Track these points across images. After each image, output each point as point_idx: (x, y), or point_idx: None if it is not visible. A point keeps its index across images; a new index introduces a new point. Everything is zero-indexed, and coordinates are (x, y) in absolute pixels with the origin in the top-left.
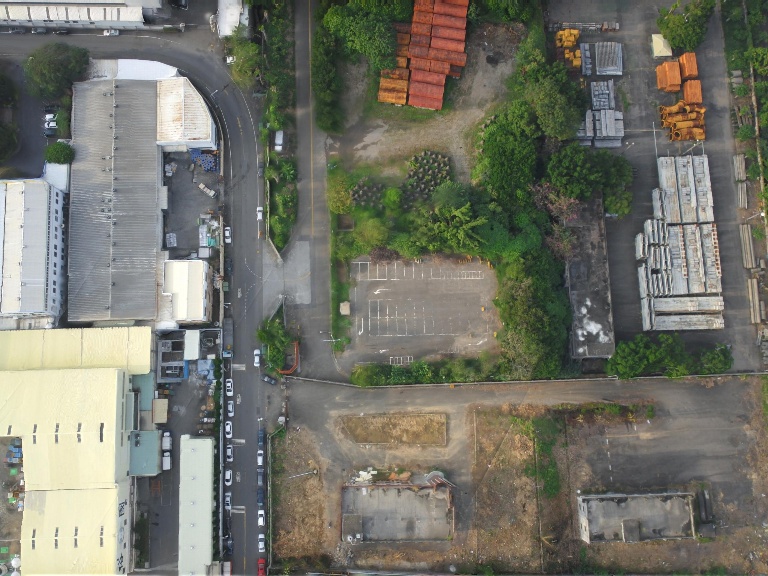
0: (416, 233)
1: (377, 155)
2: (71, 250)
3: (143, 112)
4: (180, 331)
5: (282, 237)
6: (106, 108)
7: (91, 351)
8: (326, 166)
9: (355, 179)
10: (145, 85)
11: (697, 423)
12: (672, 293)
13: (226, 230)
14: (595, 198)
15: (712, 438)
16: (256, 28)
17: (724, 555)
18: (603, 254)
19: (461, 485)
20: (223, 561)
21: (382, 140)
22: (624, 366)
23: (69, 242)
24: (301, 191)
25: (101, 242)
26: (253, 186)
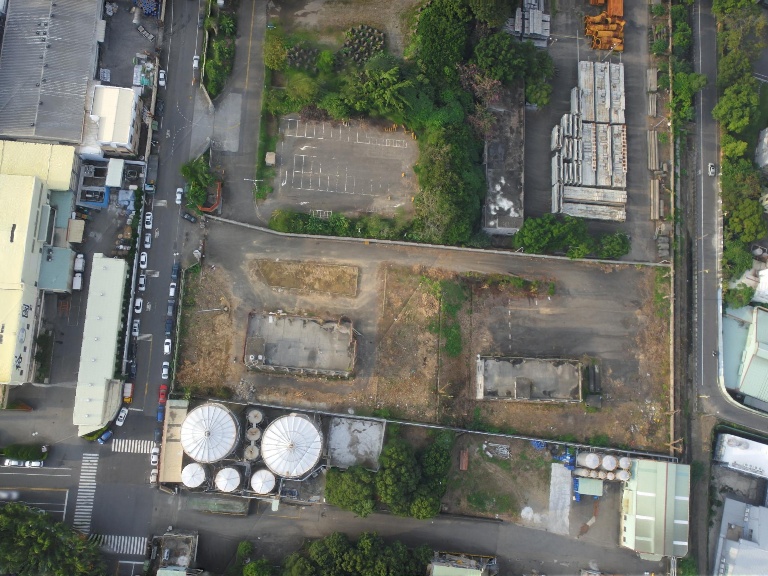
0: (345, 91)
1: (316, 23)
2: (1, 67)
3: None
4: (105, 162)
5: (215, 84)
6: None
7: (11, 163)
8: (266, 27)
9: (293, 42)
10: None
11: (594, 304)
12: (581, 182)
13: (161, 72)
14: (517, 87)
15: (606, 319)
16: None
17: (608, 425)
18: (520, 138)
19: (367, 334)
20: (124, 382)
21: (322, 10)
22: (530, 238)
23: (0, 60)
24: (239, 47)
25: (33, 63)
26: (192, 36)
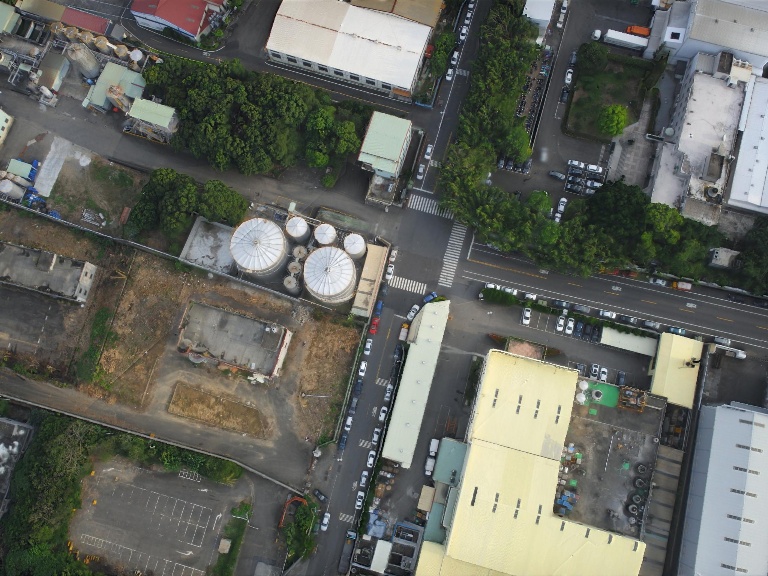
0: None
1: None
2: None
3: None
4: (393, 574)
5: None
6: None
7: None
8: None
9: None
10: None
11: None
12: None
13: None
14: None
15: None
16: None
17: None
18: None
19: None
20: None
21: None
22: None
23: None
24: None
25: None
26: None
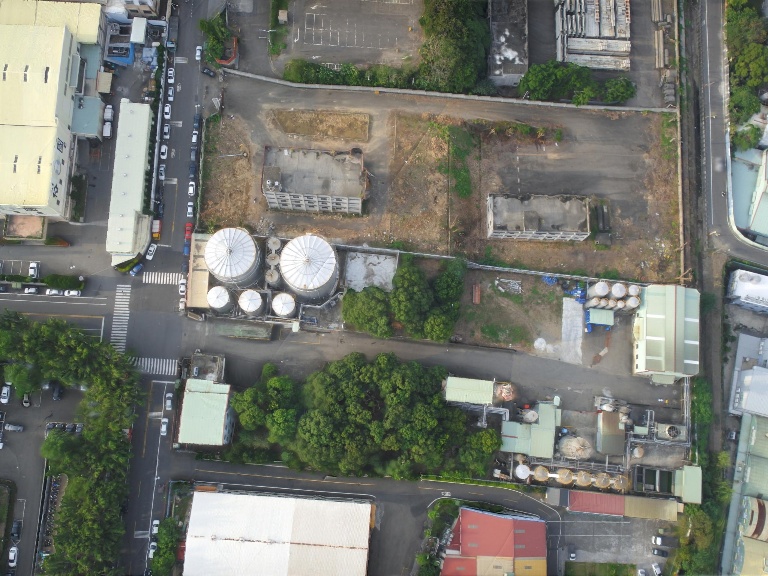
0: None
1: None
2: None
3: None
4: (129, 24)
5: None
6: None
7: (44, 20)
8: None
9: None
10: None
11: (601, 149)
12: (584, 32)
13: None
14: None
15: (614, 162)
16: None
17: (618, 262)
18: None
19: (379, 176)
20: (153, 219)
21: None
22: (534, 81)
23: None
24: None
25: None
26: None
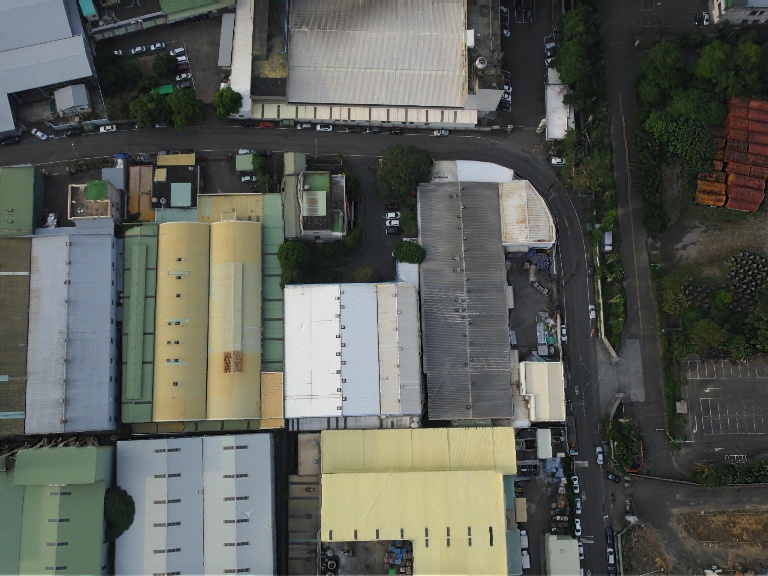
0: (756, 336)
1: (697, 255)
2: (427, 349)
3: (490, 214)
4: (525, 428)
5: (619, 336)
6: (453, 209)
7: (459, 451)
8: (649, 265)
9: (678, 279)
10: (488, 187)
11: None
12: None
13: (563, 328)
14: None
15: None
16: (581, 131)
17: None
18: None
19: None
20: None
21: (700, 240)
22: None
23: (424, 341)
24: (627, 290)
25: (457, 342)
26: (583, 284)
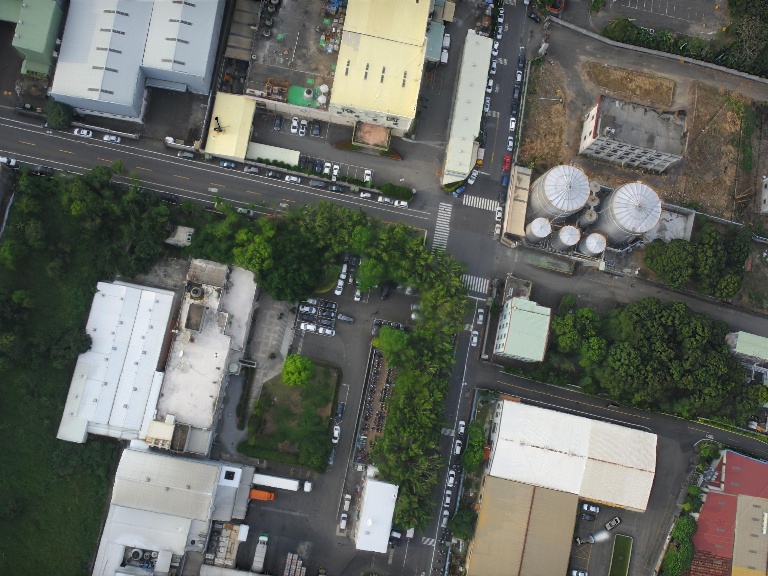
0: None
1: None
2: None
3: None
4: None
5: None
6: None
7: None
8: None
9: None
10: None
11: None
12: None
13: None
14: None
15: None
16: None
17: None
18: None
19: None
20: (479, 147)
21: None
22: None
23: None
24: None
25: None
26: None
